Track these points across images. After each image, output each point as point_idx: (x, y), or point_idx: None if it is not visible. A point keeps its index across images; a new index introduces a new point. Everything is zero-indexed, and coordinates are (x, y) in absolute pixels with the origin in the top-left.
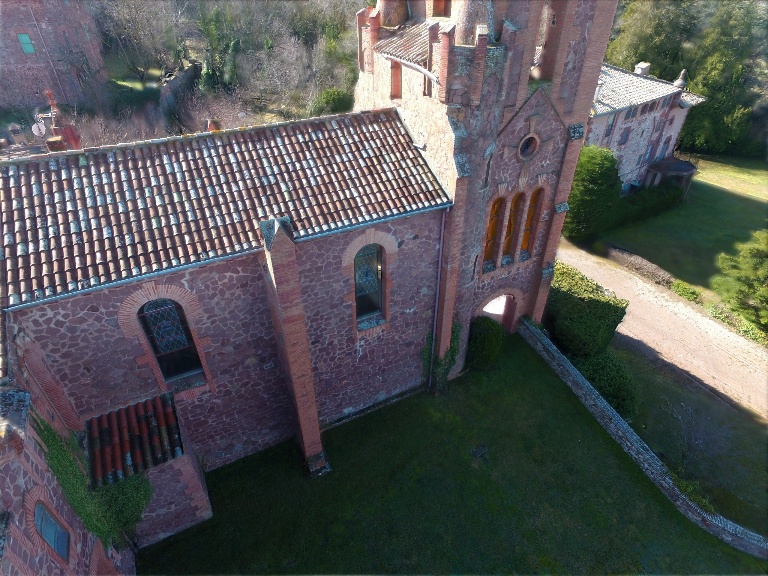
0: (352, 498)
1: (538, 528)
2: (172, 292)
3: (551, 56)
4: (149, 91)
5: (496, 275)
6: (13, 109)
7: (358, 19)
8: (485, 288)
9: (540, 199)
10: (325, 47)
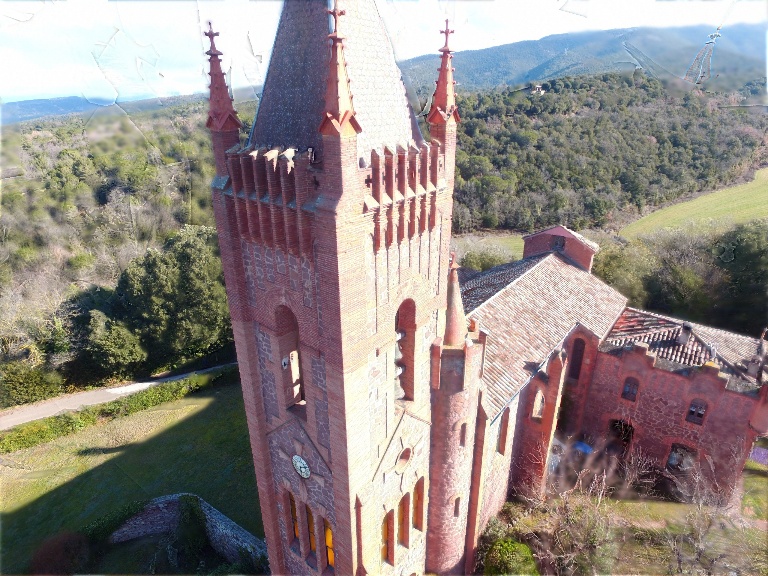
0: None
1: None
2: None
3: None
4: None
5: None
6: None
7: None
8: None
9: None
10: None
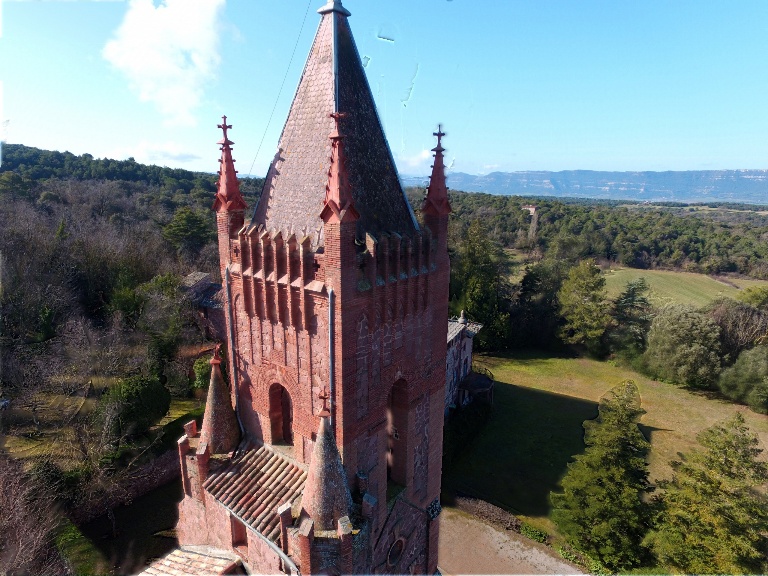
0: None
1: None
2: None
3: (400, 464)
4: None
5: None
6: None
7: (180, 448)
8: None
9: None
10: (121, 318)
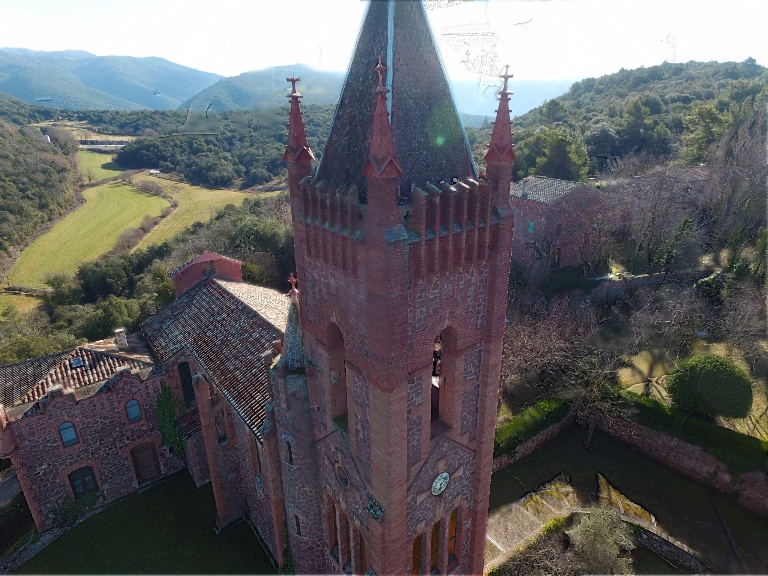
0: (197, 553)
1: None
2: None
3: None
4: (581, 281)
5: (341, 572)
6: None
7: None
8: (336, 572)
9: None
10: None
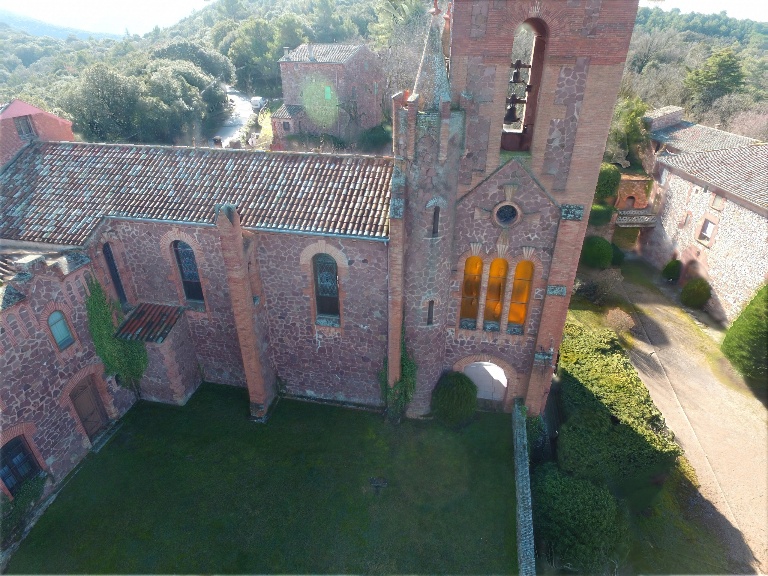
0: (259, 448)
1: (367, 571)
2: (188, 239)
3: (534, 131)
4: (391, 135)
5: (477, 336)
6: (300, 134)
7: None
8: (465, 345)
9: (533, 274)
10: None
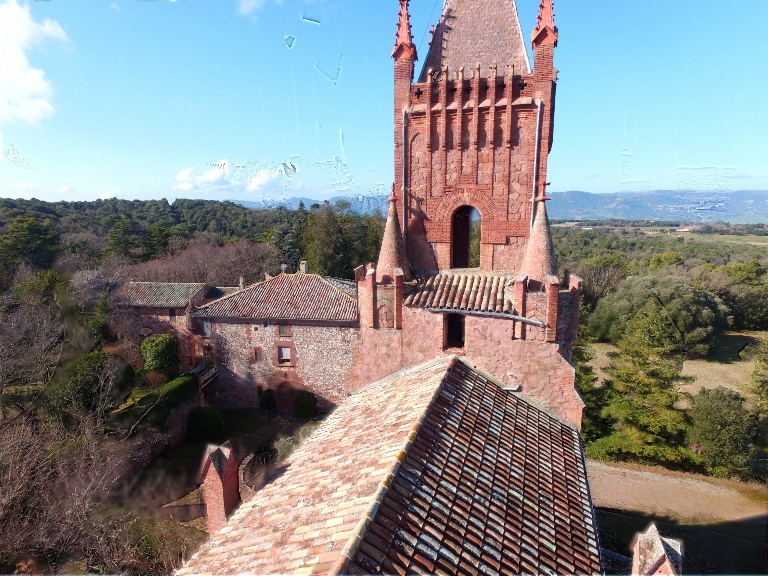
0: None
1: None
2: None
3: None
4: None
5: None
6: None
7: (372, 279)
8: None
9: None
10: None
